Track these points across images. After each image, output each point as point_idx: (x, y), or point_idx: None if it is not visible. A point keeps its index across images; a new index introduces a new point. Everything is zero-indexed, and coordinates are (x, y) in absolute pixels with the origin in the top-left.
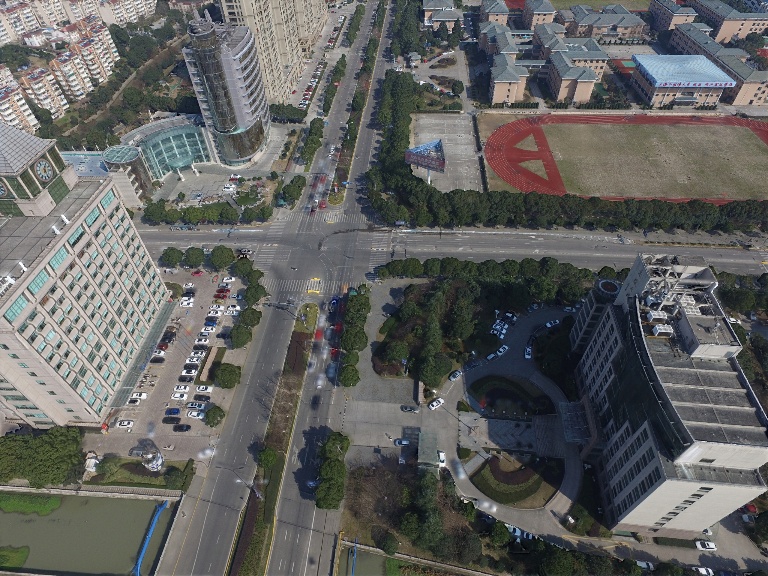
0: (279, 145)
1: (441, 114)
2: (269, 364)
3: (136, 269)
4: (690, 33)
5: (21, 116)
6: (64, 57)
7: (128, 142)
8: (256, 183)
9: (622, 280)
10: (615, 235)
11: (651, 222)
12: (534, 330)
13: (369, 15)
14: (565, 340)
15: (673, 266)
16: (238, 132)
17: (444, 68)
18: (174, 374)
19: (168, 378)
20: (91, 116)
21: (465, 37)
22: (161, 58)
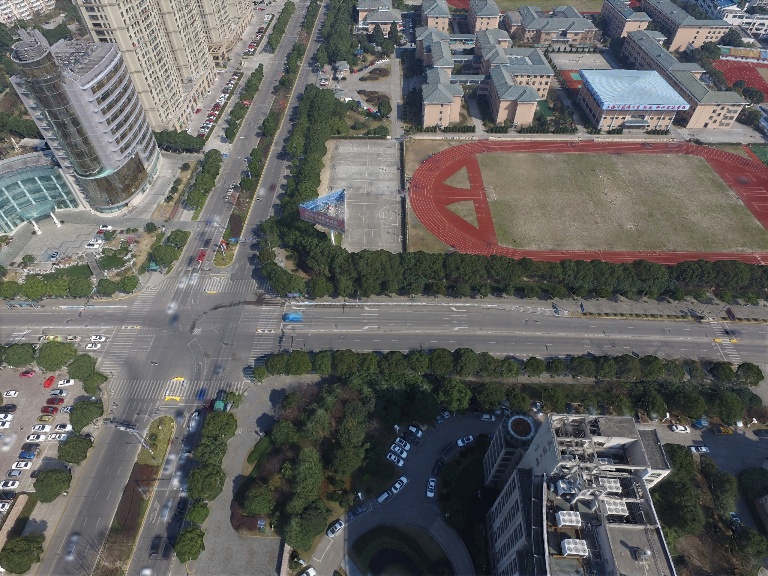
0: (168, 183)
1: (365, 140)
2: (94, 518)
3: None
4: (643, 43)
5: None
6: None
7: None
8: (128, 237)
9: (553, 373)
10: (549, 304)
11: (591, 288)
12: (442, 450)
13: (300, 13)
14: (478, 468)
15: (592, 438)
16: (103, 175)
17: (375, 80)
18: None
19: None
20: None
21: (403, 42)
22: None
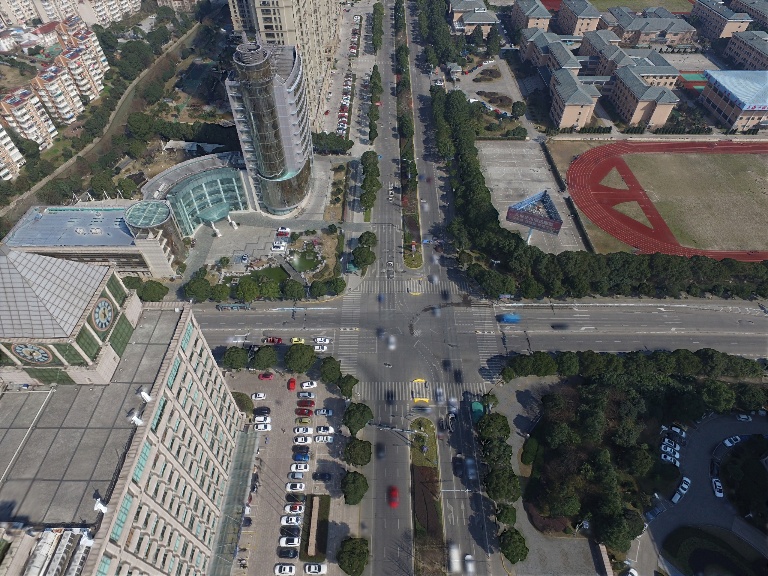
0: (326, 184)
1: (504, 141)
2: (392, 520)
3: (215, 410)
4: (754, 43)
5: (2, 152)
6: (49, 73)
7: (152, 194)
8: (312, 239)
9: None
10: (756, 304)
11: None
12: (712, 451)
13: (387, 14)
14: (759, 468)
15: None
16: (288, 177)
17: (490, 81)
18: (269, 544)
19: (262, 551)
20: (87, 145)
21: (502, 43)
22: (161, 69)
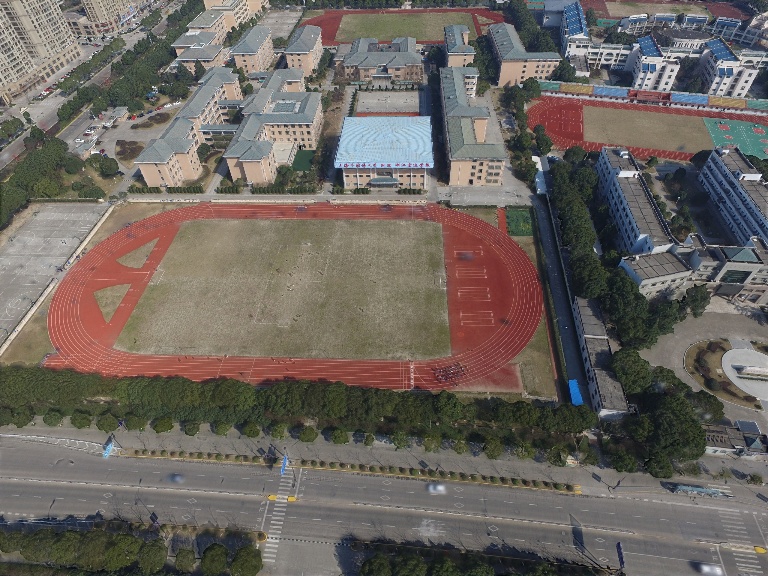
0: None
1: (74, 204)
2: None
3: None
4: (444, 82)
5: None
6: None
7: None
8: None
9: None
10: (106, 436)
11: (158, 416)
12: None
13: None
14: None
15: None
16: None
17: (147, 128)
18: None
19: None
20: None
21: None
22: None
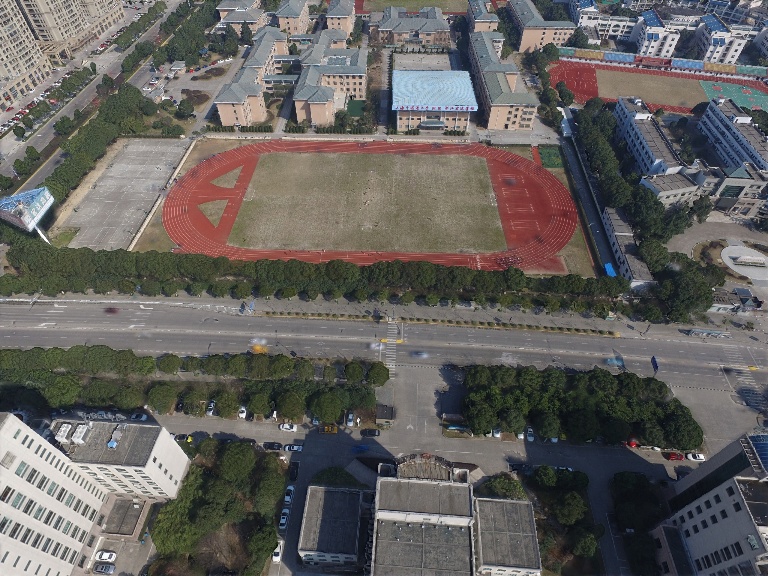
0: None
1: (158, 139)
2: None
3: None
4: (476, 44)
5: None
6: None
7: None
8: None
9: (190, 371)
10: (239, 303)
11: (281, 287)
12: None
13: None
14: None
15: None
16: None
17: (206, 80)
18: None
19: None
20: None
21: None
22: None
